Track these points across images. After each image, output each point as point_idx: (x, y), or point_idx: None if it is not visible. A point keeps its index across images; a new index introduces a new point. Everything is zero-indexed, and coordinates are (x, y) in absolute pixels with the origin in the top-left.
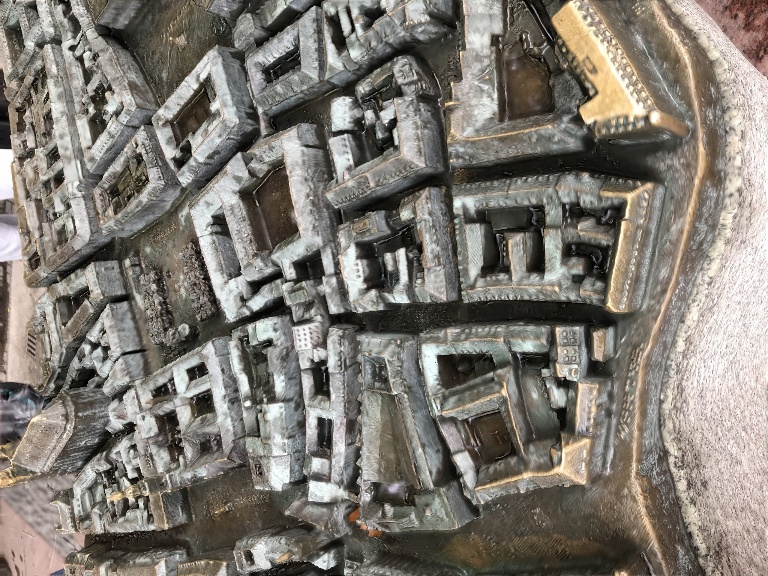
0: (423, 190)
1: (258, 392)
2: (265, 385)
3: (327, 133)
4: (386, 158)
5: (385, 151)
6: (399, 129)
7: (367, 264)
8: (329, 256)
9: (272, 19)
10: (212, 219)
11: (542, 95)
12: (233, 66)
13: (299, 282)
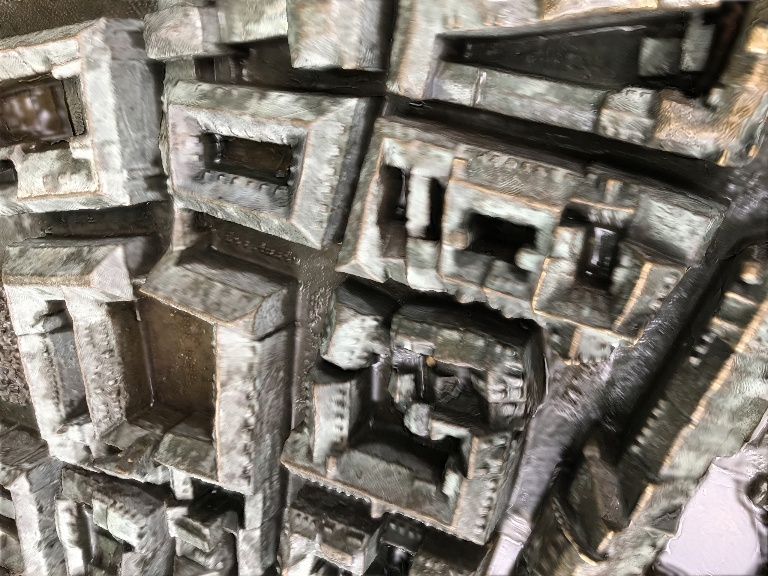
0: (465, 575)
1: (96, 573)
2: (109, 572)
3: (301, 297)
4: (419, 503)
5: (419, 481)
6: (464, 489)
7: (323, 573)
8: (258, 504)
9: (244, 36)
10: (47, 305)
11: (727, 547)
12: (132, 67)
13: (197, 517)
